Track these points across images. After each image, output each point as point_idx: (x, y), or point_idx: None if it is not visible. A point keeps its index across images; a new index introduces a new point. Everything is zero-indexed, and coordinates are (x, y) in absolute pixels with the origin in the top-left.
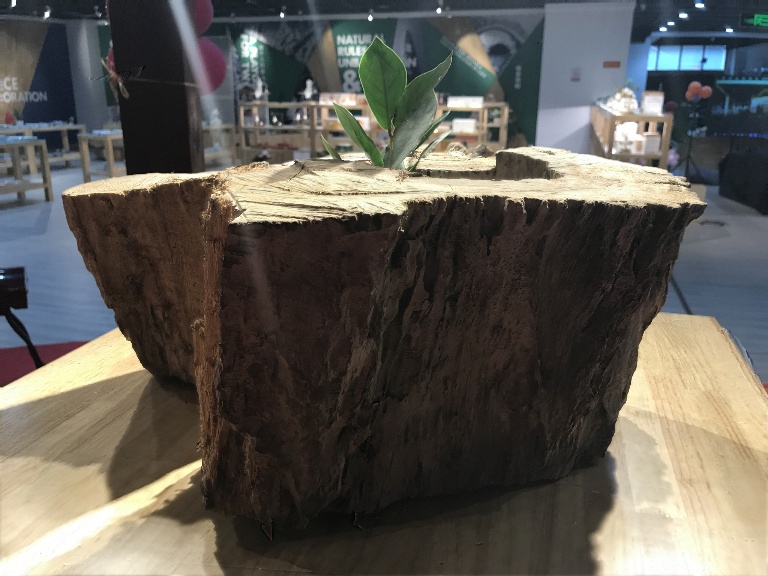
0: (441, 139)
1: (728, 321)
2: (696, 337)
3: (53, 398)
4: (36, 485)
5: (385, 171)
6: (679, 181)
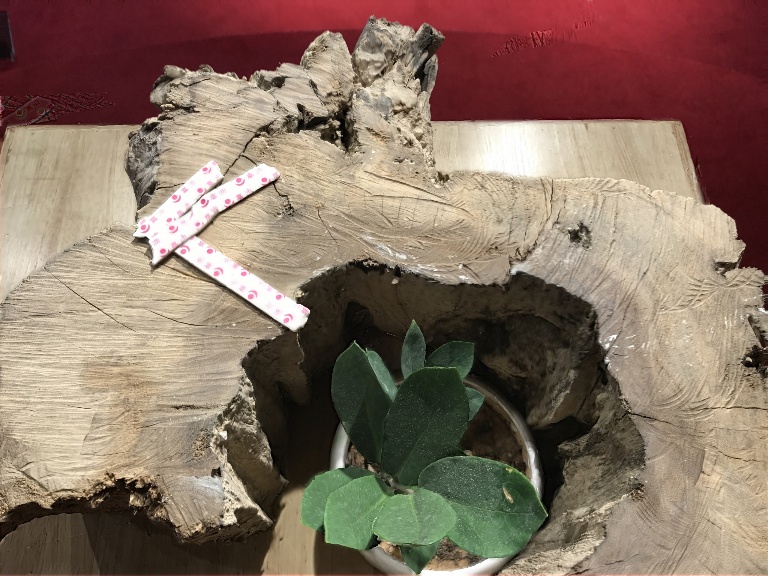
0: (470, 418)
1: (698, 160)
2: None
3: None
4: None
5: None
6: (763, 321)
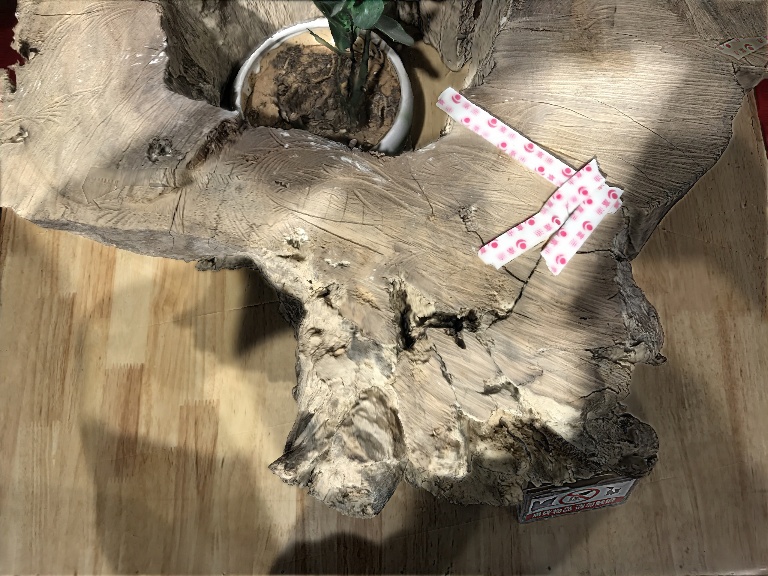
0: None
1: None
2: (11, 460)
3: None
4: None
5: None
6: (2, 88)
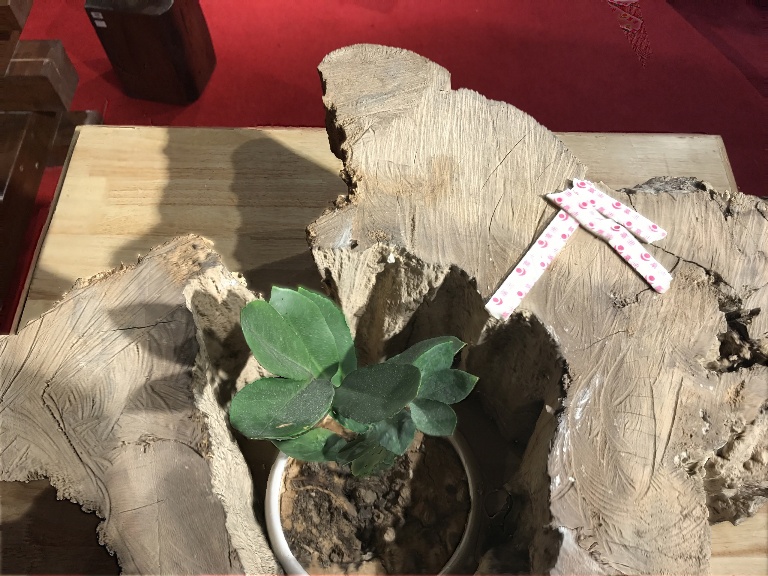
0: (382, 442)
1: None
2: None
3: (327, 175)
4: (207, 244)
5: (171, 415)
6: None
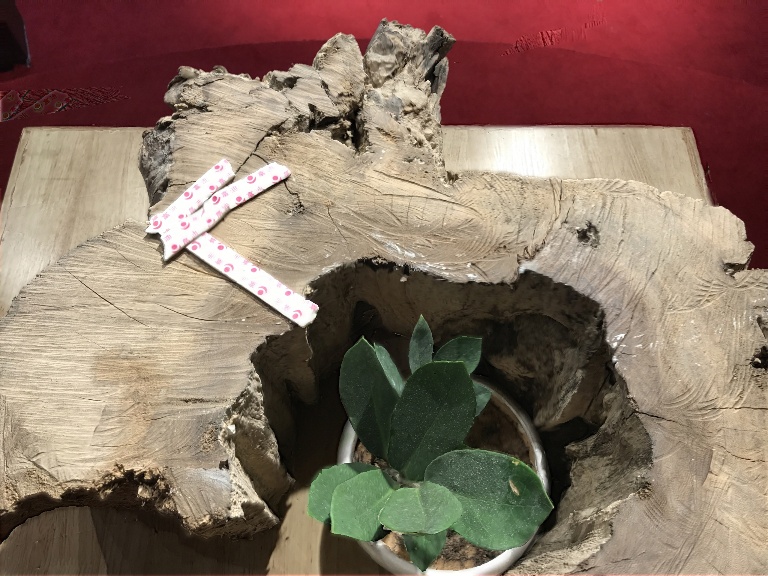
0: (477, 413)
1: None
2: None
3: None
4: None
5: None
6: None
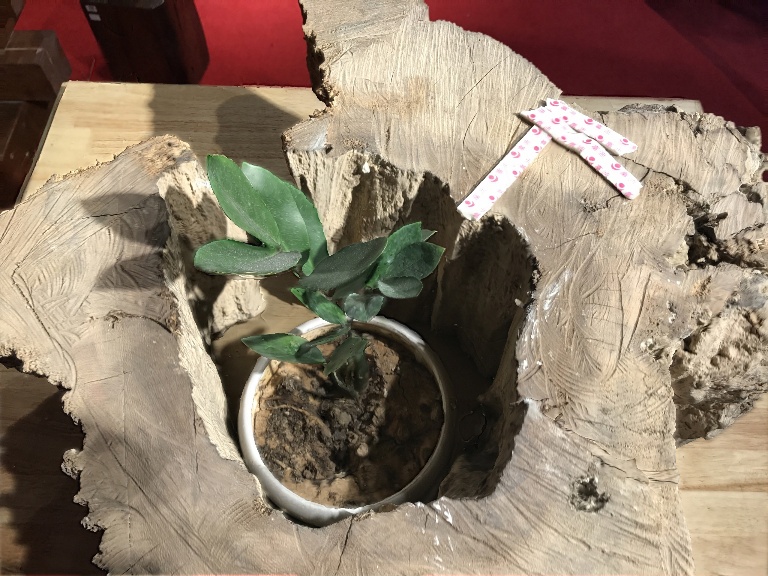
0: (349, 313)
1: None
2: None
3: None
4: None
5: (140, 292)
6: None
